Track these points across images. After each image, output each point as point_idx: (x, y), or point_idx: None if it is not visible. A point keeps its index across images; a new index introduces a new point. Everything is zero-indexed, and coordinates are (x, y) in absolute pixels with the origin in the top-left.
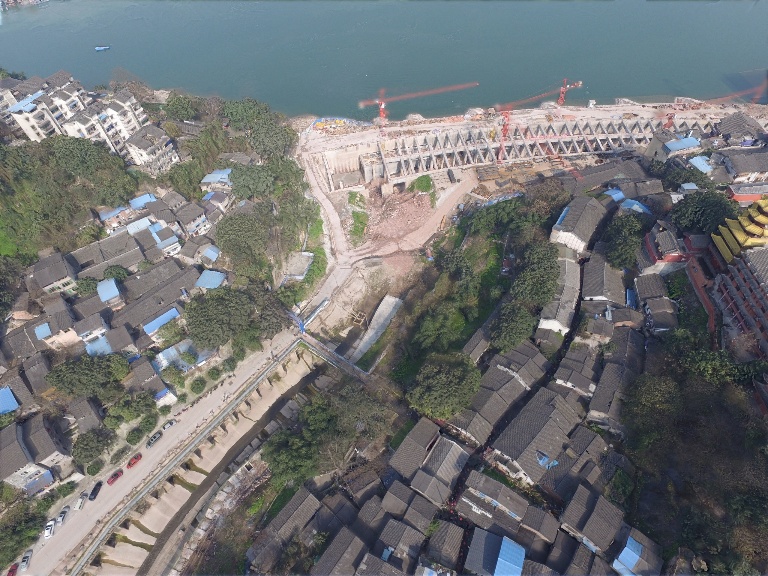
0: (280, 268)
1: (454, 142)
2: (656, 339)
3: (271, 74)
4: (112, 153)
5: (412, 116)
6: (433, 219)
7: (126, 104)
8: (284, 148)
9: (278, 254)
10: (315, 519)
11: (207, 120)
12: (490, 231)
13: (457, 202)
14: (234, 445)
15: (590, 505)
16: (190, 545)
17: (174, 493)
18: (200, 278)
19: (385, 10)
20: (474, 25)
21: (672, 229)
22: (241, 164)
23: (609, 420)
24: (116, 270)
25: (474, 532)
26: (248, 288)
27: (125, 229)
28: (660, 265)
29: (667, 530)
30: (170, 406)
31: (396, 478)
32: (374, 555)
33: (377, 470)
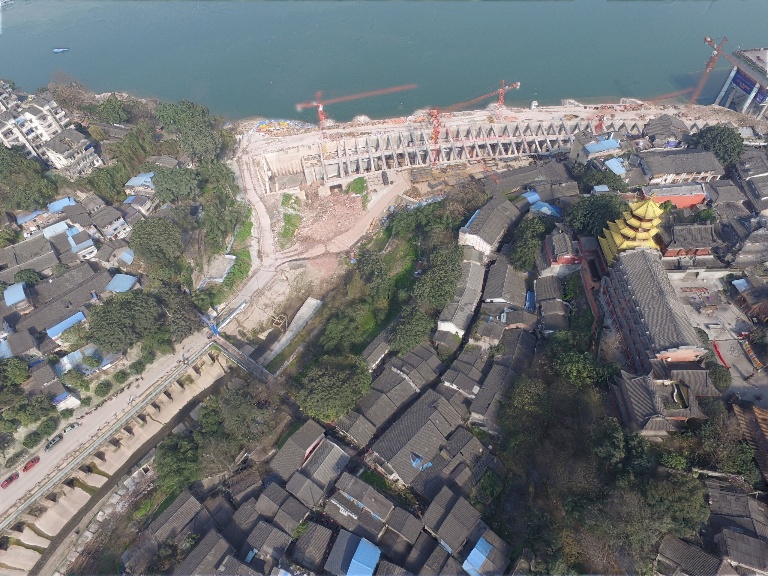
0: (201, 271)
1: (397, 144)
2: (546, 341)
3: (225, 76)
4: (33, 157)
5: (358, 118)
6: (363, 221)
7: (45, 108)
8: (215, 151)
9: (198, 257)
10: (193, 521)
11: (138, 123)
12: (411, 233)
13: (388, 204)
14: (139, 448)
15: (450, 506)
16: (77, 548)
17: (73, 496)
18: (111, 282)
19: (345, 11)
20: (432, 26)
21: (569, 231)
22: (167, 167)
23: (487, 422)
24: (27, 274)
25: (339, 534)
26: (159, 291)
27: (41, 233)
28: (555, 267)
29: (520, 531)
30: (73, 409)
31: (278, 480)
32: (239, 557)
33: (261, 472)
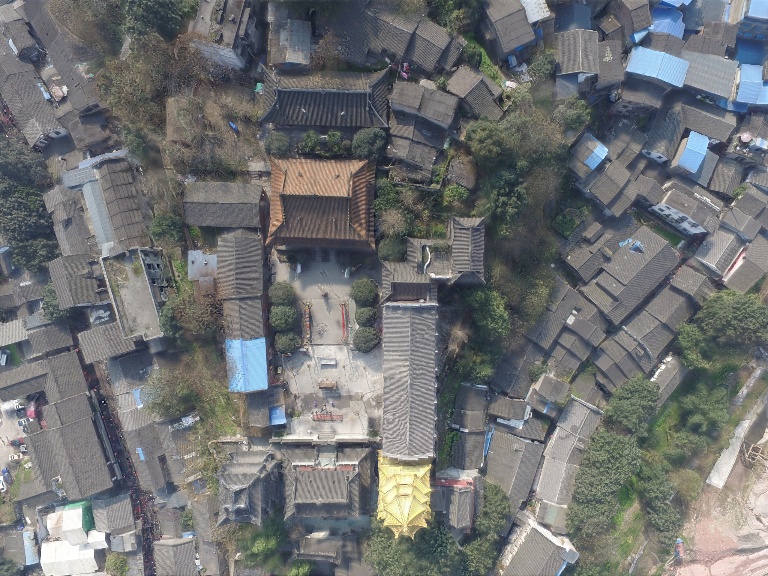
0: None
1: None
2: None
3: None
4: None
5: None
6: None
7: None
8: None
9: None
10: None
11: None
12: None
13: None
14: None
15: (617, 197)
16: None
17: None
18: None
19: None
20: None
21: None
22: None
23: None
24: None
25: None
26: None
27: None
28: (465, 477)
29: None
30: None
31: None
32: None
33: None
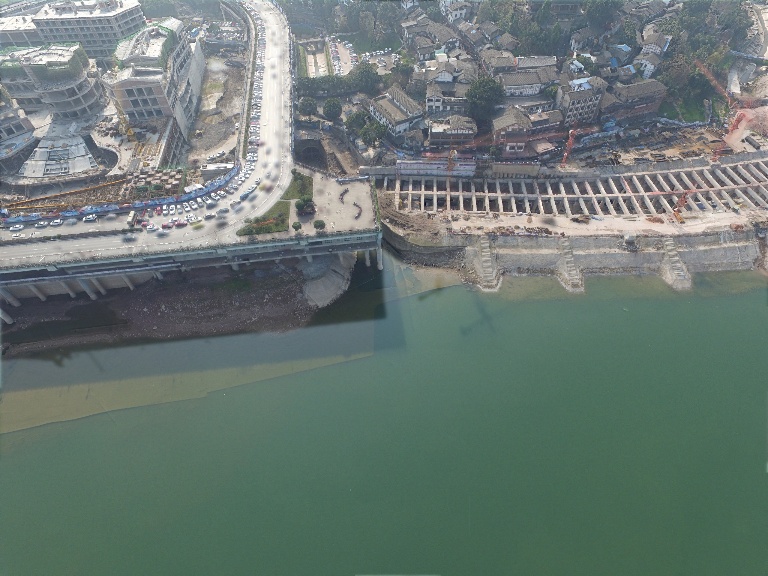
0: None
1: None
2: None
3: None
4: None
5: None
6: (743, 124)
7: None
8: None
9: None
10: None
11: None
12: None
13: None
14: (766, 50)
15: None
16: None
17: None
18: None
19: None
20: None
21: None
22: None
23: None
24: None
25: None
26: None
27: None
28: None
29: None
30: None
31: None
32: None
33: None
